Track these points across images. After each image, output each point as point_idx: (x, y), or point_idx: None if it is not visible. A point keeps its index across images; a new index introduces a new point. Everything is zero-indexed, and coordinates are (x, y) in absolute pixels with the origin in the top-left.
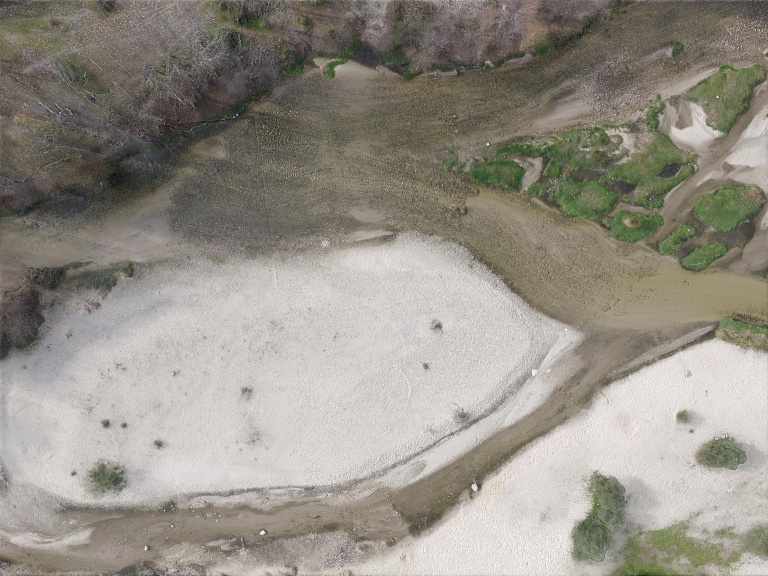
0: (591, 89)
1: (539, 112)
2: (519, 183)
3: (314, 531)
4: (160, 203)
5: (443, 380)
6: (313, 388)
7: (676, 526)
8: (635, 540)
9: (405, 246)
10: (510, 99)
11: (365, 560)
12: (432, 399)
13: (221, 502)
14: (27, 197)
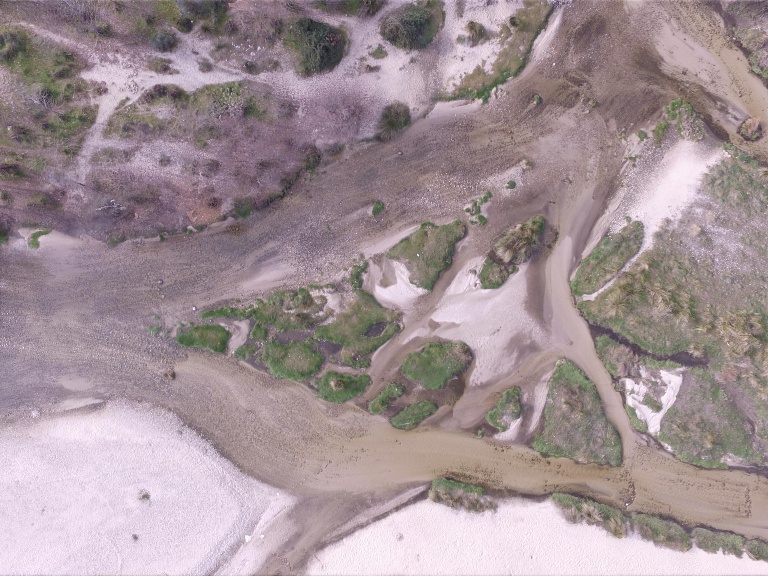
0: (294, 250)
1: (244, 275)
2: (226, 347)
3: None
4: None
5: (153, 550)
6: (23, 563)
7: None
8: None
9: (114, 414)
10: (215, 262)
11: None
12: (143, 570)
13: None
14: None
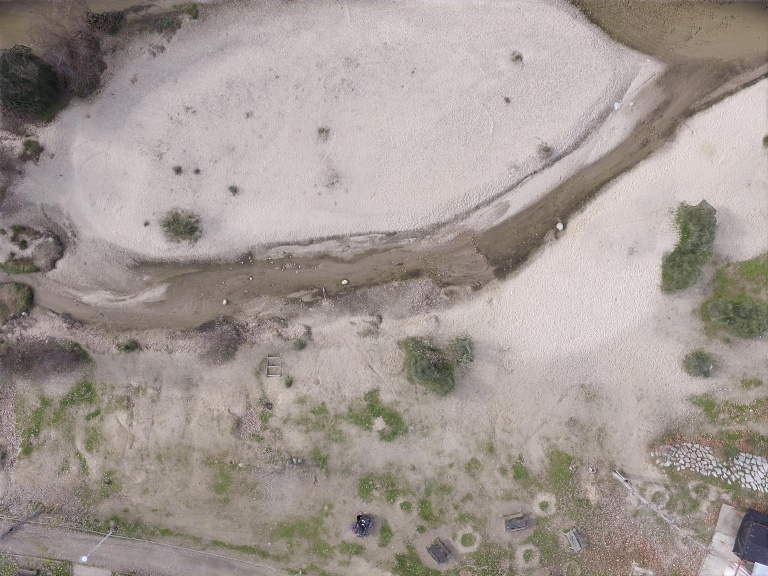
0: None
1: None
2: None
3: (397, 278)
4: None
5: (525, 114)
6: (392, 127)
7: (764, 255)
8: (723, 272)
9: None
10: None
11: (451, 305)
12: (515, 134)
13: (300, 252)
14: None
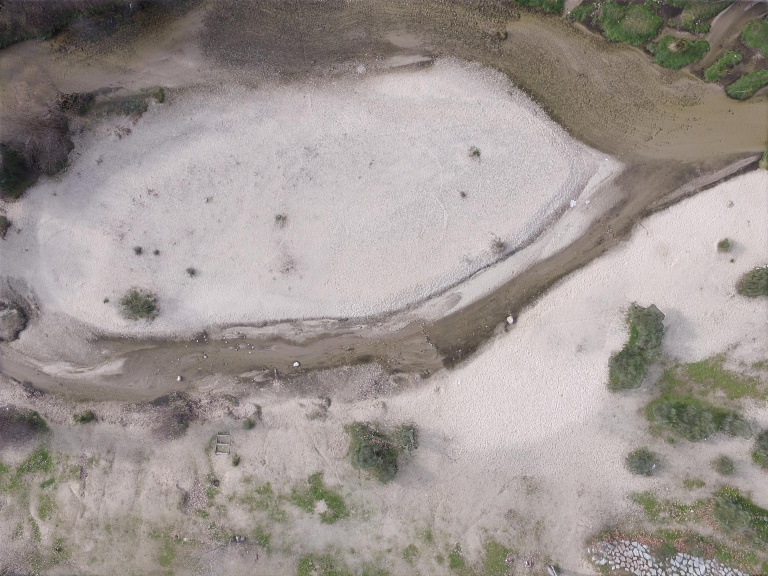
0: None
1: None
2: (561, 6)
3: (348, 363)
4: (191, 26)
5: (480, 209)
6: (348, 216)
7: (713, 358)
8: (671, 373)
9: (443, 72)
10: None
11: (399, 392)
12: (469, 228)
13: (254, 333)
14: (55, 16)
